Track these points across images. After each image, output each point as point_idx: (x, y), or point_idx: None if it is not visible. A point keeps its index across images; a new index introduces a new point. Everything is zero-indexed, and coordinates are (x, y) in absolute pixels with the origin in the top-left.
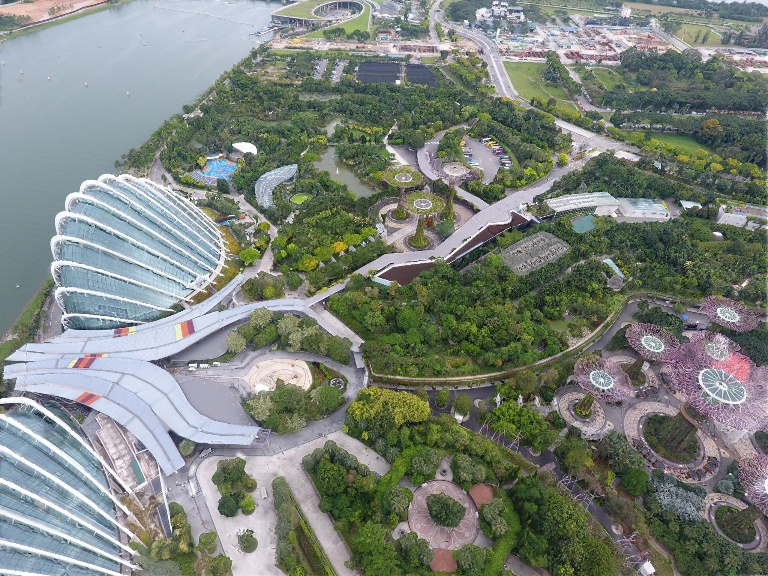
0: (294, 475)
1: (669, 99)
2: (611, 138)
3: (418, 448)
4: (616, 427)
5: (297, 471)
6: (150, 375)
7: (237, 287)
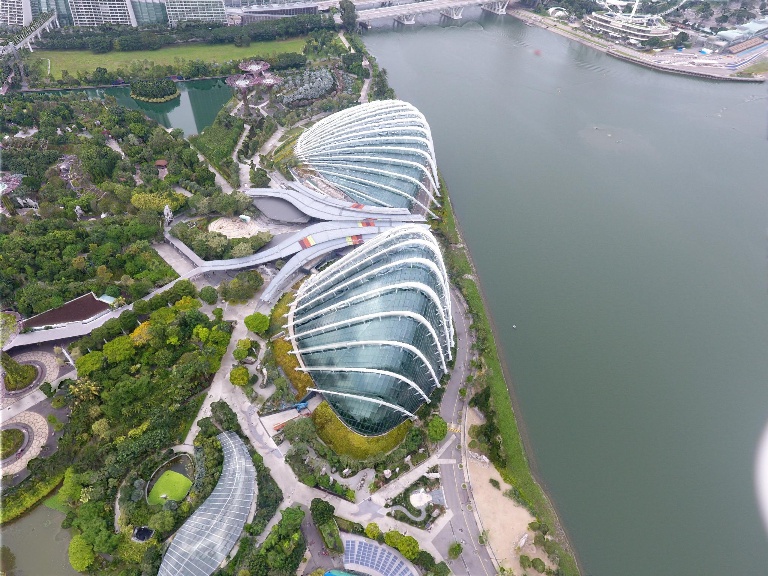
0: (229, 191)
1: None
2: None
3: (150, 188)
4: (5, 213)
5: (227, 192)
6: (321, 214)
7: (272, 300)
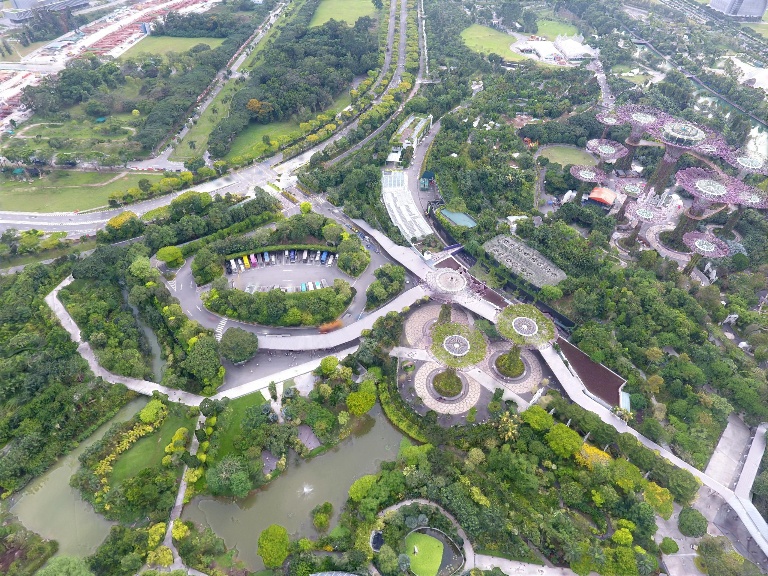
0: None
1: (181, 109)
2: (242, 168)
3: None
4: (686, 264)
5: None
6: None
7: None
